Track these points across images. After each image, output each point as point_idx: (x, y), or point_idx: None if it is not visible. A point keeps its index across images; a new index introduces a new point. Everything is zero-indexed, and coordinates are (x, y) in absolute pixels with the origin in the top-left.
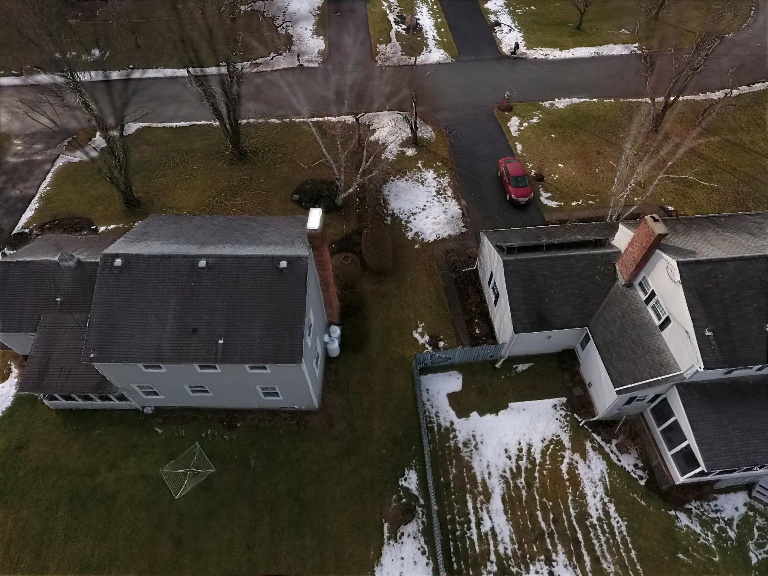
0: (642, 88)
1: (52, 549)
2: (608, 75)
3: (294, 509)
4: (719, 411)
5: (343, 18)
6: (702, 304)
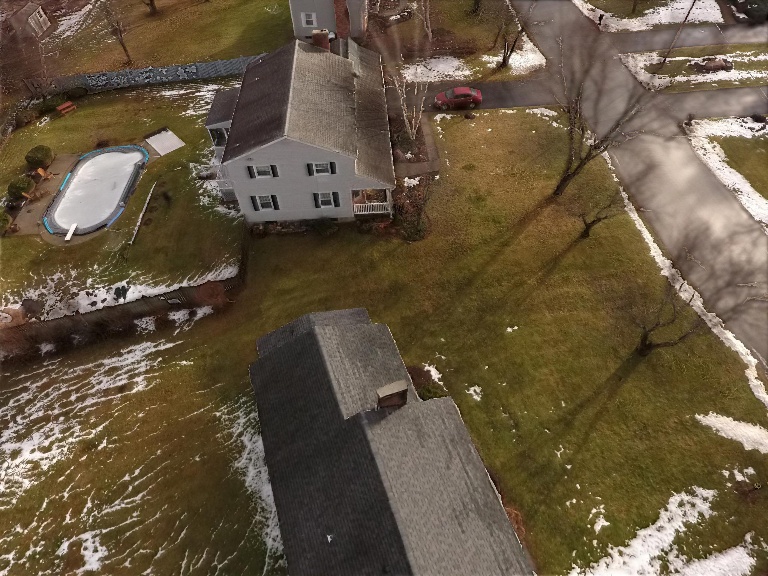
0: (658, 209)
1: None
2: (676, 186)
3: None
4: None
5: (696, 34)
6: None
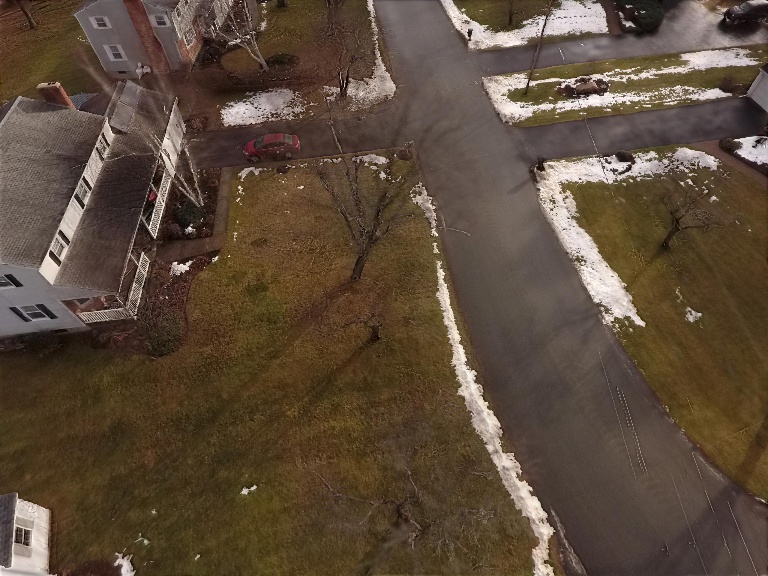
0: (477, 293)
1: None
2: (506, 257)
3: (70, 80)
4: None
5: (574, 49)
6: None
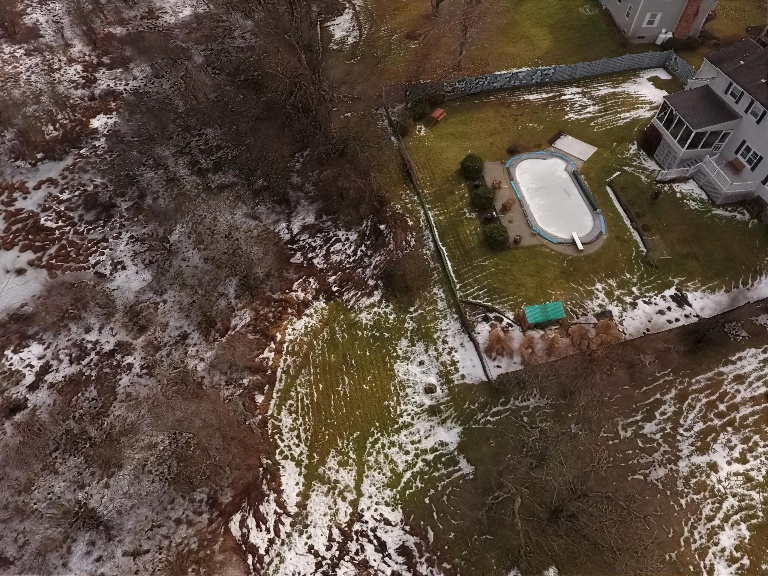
0: None
1: (550, 8)
2: None
3: (584, 44)
4: (700, 98)
5: None
6: (760, 56)
